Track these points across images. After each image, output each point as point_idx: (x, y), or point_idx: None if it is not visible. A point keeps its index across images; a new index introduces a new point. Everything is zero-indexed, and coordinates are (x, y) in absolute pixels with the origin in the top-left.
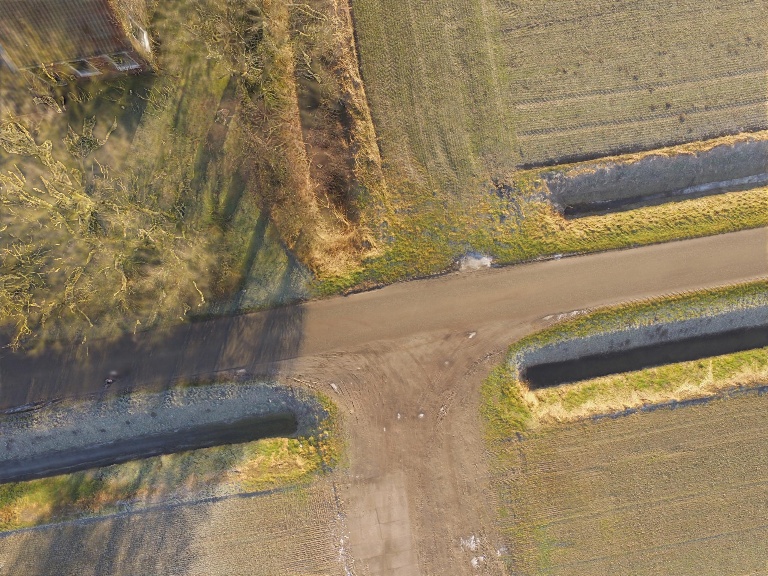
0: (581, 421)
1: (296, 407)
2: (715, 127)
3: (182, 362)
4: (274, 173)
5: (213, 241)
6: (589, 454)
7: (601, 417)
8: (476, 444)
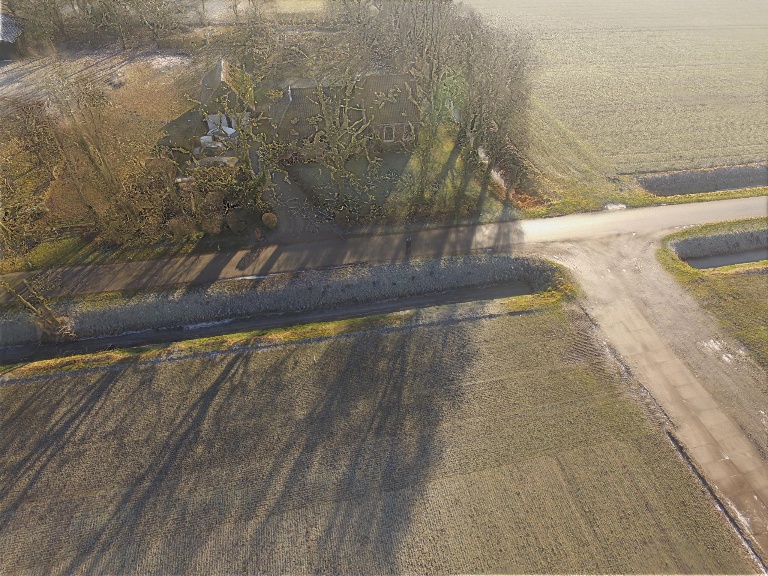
0: (740, 274)
1: (531, 274)
2: (711, 164)
3: (449, 245)
4: (504, 143)
5: (458, 195)
6: (761, 290)
7: (752, 273)
8: (674, 285)
